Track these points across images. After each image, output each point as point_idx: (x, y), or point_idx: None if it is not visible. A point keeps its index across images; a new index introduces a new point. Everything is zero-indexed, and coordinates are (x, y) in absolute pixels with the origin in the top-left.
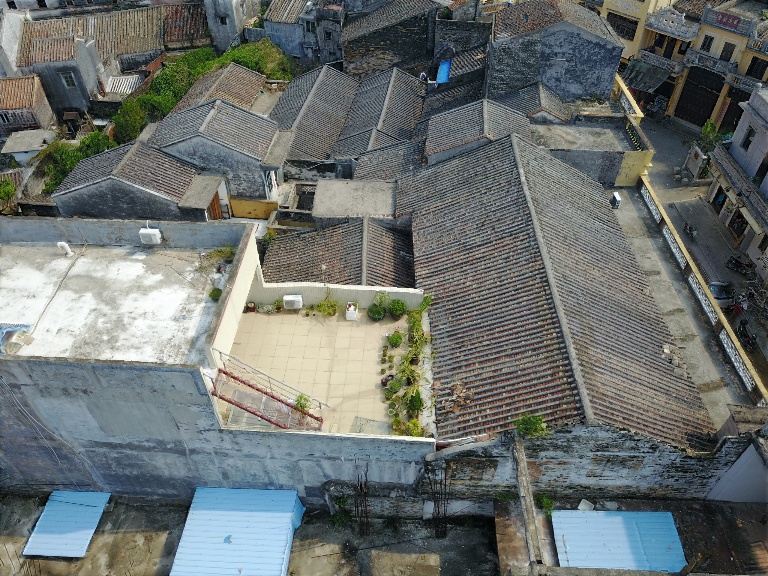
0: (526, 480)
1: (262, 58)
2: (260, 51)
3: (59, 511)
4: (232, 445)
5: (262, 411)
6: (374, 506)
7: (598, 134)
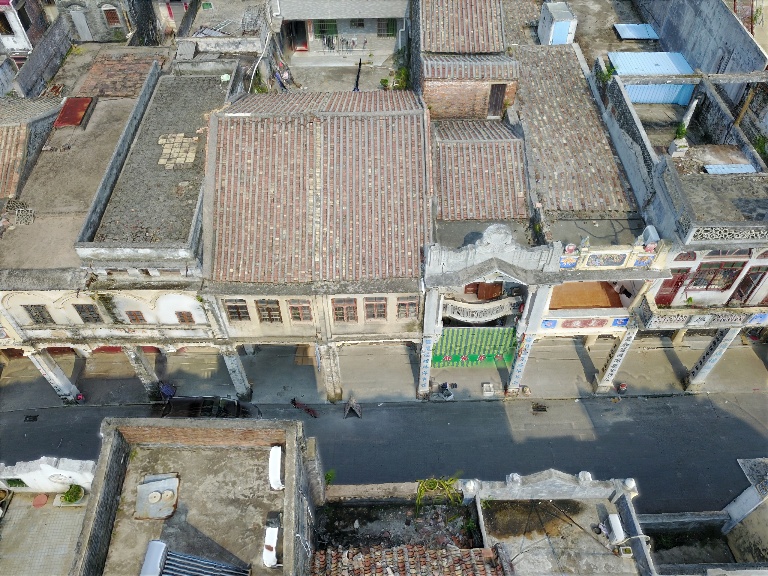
0: (763, 74)
1: None
2: None
3: (640, 28)
4: (712, 15)
5: (741, 7)
6: (711, 117)
7: None
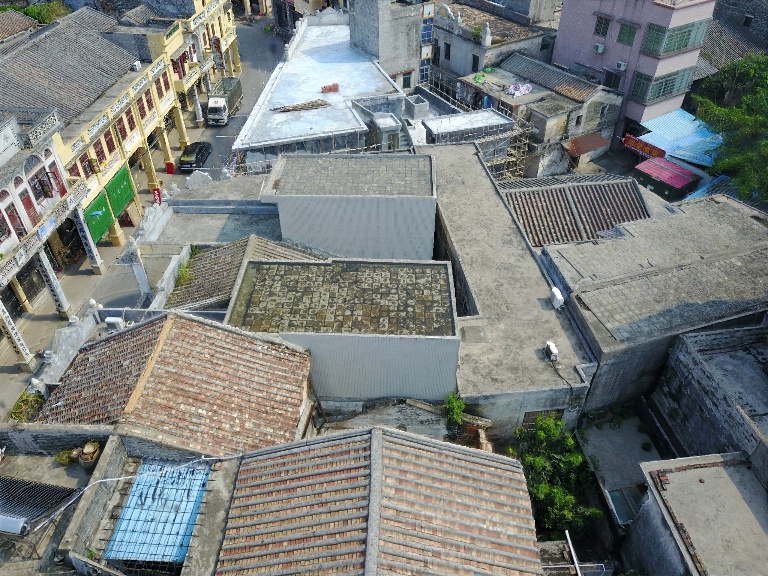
0: None
1: (47, 11)
2: (50, 8)
3: None
4: None
5: None
6: None
7: (158, 31)
